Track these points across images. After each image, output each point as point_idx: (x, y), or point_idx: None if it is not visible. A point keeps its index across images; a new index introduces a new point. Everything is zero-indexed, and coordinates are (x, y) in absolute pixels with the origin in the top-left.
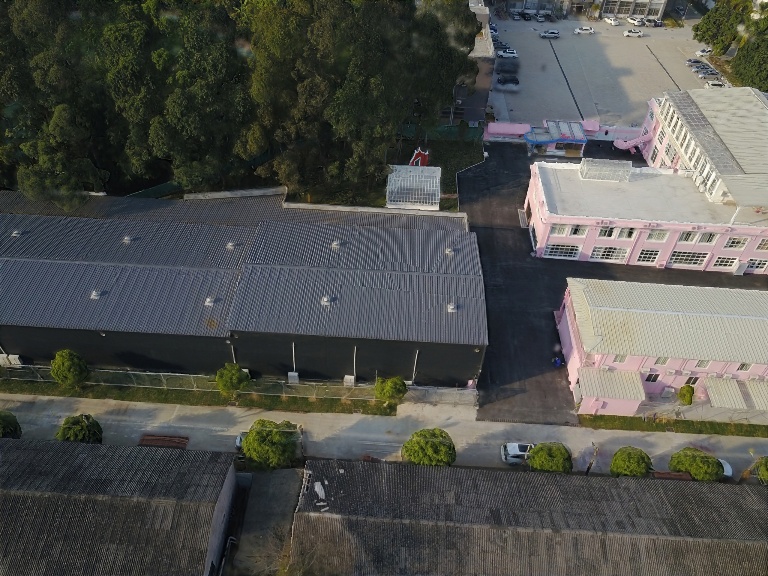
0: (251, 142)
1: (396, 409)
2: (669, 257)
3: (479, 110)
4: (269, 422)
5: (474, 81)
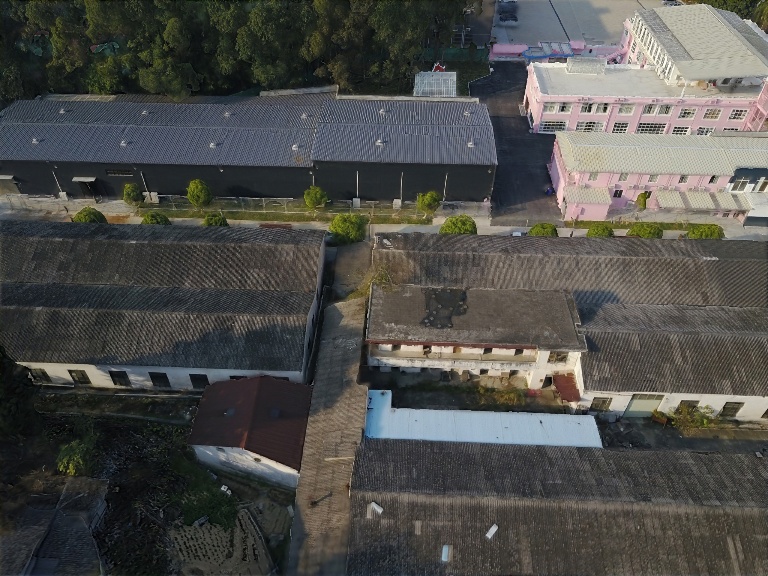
0: (313, 45)
1: (432, 221)
2: (636, 128)
3: (485, 36)
4: None
5: (481, 3)
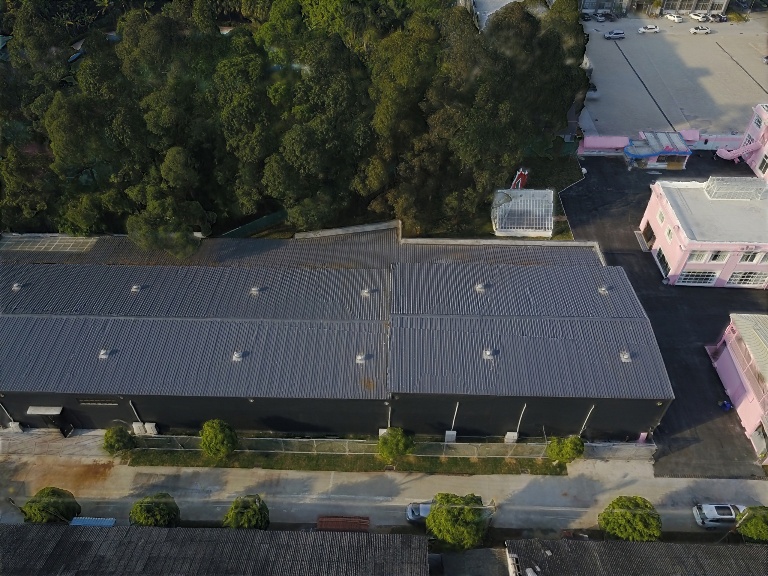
0: (372, 177)
1: (566, 467)
2: None
3: (571, 123)
4: (453, 496)
5: (584, 97)
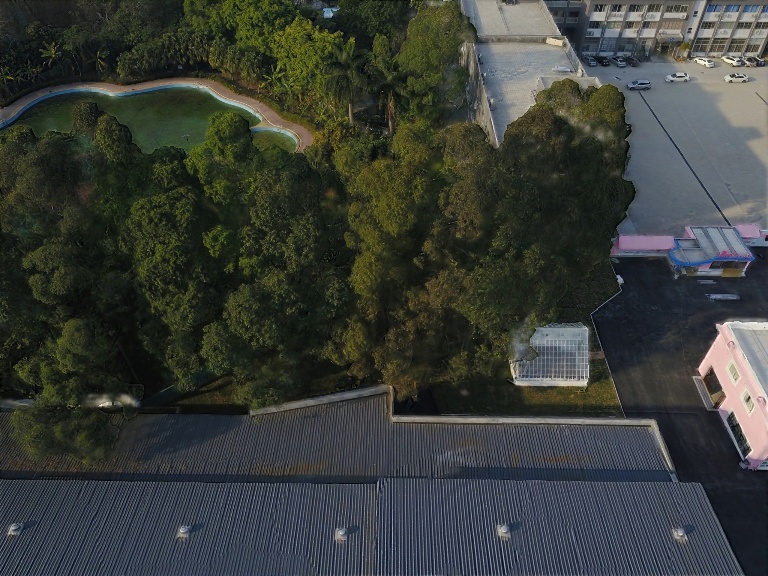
0: (351, 349)
1: None
2: None
3: None
4: None
5: None
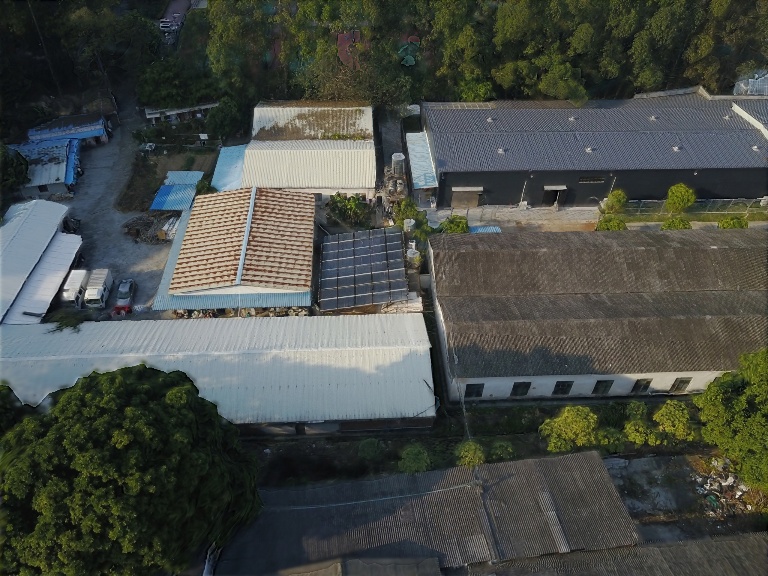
0: (705, 47)
1: None
2: None
3: None
4: None
5: None
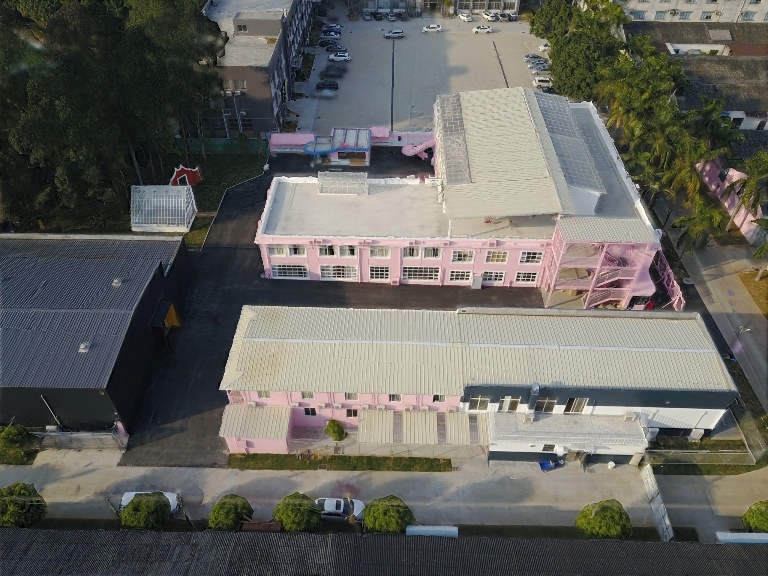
0: None
1: (35, 457)
2: (401, 273)
3: (267, 120)
4: None
5: (218, 94)
